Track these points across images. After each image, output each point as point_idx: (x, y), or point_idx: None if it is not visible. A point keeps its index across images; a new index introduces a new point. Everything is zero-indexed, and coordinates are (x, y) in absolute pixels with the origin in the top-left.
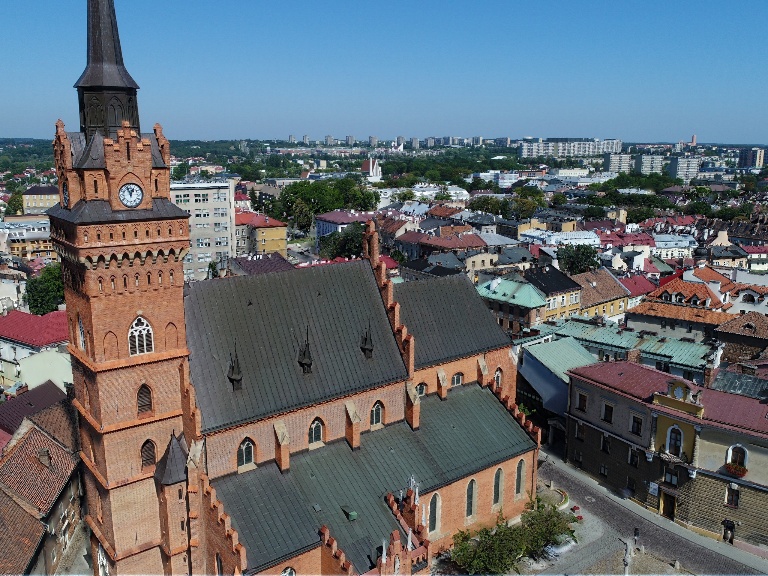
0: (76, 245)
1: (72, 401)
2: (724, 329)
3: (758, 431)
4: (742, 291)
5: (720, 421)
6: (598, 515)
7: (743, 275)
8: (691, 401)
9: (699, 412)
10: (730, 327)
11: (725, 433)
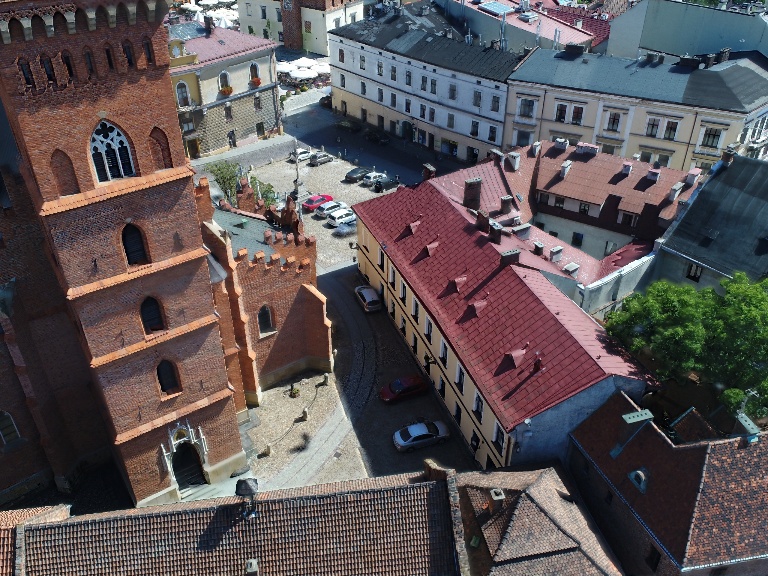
0: None
1: (68, 297)
2: None
3: (231, 54)
4: None
5: (209, 59)
6: None
7: None
8: (187, 54)
9: (196, 59)
10: None
11: (214, 67)
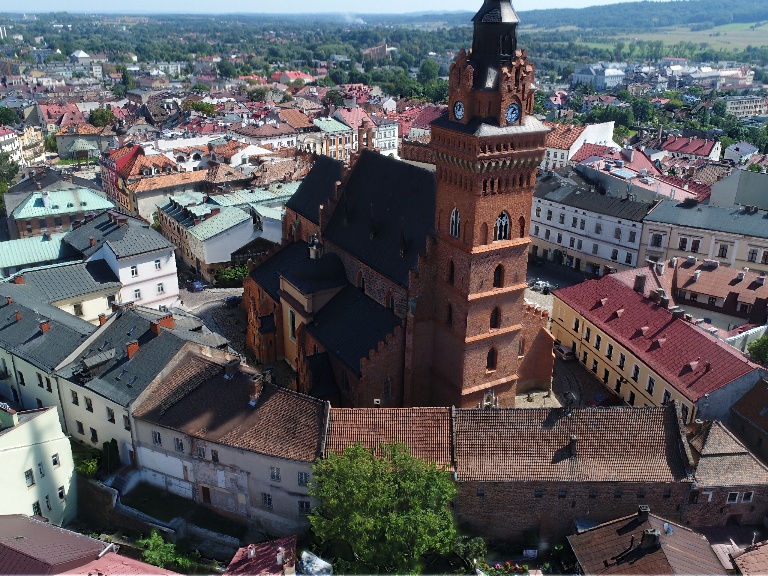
0: (541, 148)
1: (469, 299)
2: (219, 181)
3: None
4: None
5: None
6: None
7: (163, 143)
8: None
9: None
10: (220, 178)
11: None
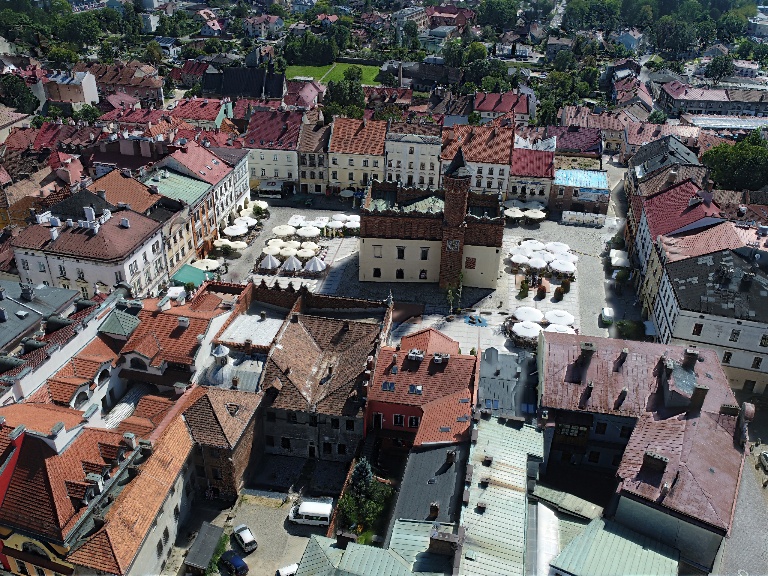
0: None
1: None
2: (235, 437)
3: None
4: None
5: None
6: (765, 562)
7: (30, 381)
8: None
9: None
10: (231, 429)
11: None
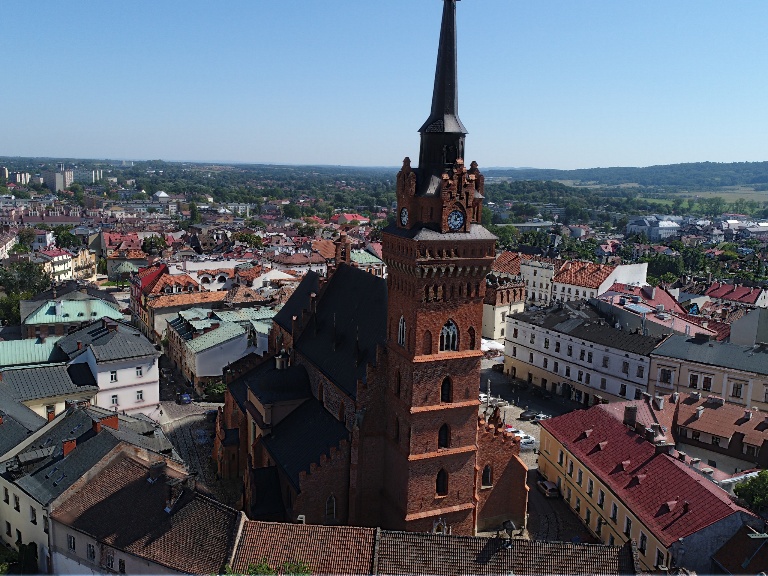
0: (489, 257)
1: (411, 411)
2: (236, 301)
3: None
4: (201, 276)
5: None
6: None
7: (191, 264)
8: None
9: None
10: (238, 299)
11: None
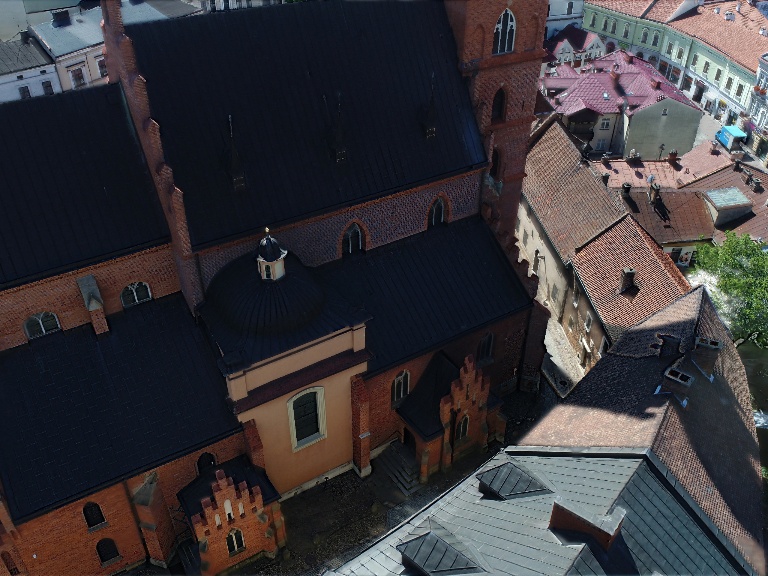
0: None
1: None
2: None
3: None
4: None
5: None
6: None
7: None
8: None
9: None
10: None
11: None
